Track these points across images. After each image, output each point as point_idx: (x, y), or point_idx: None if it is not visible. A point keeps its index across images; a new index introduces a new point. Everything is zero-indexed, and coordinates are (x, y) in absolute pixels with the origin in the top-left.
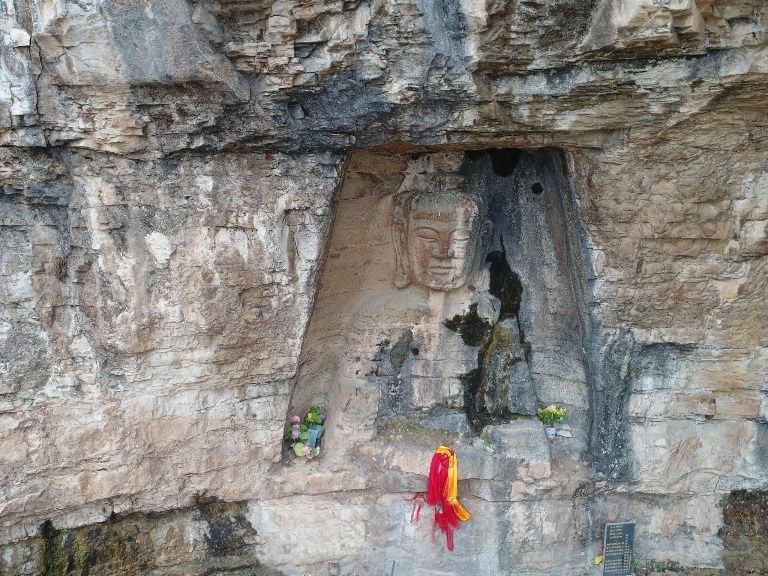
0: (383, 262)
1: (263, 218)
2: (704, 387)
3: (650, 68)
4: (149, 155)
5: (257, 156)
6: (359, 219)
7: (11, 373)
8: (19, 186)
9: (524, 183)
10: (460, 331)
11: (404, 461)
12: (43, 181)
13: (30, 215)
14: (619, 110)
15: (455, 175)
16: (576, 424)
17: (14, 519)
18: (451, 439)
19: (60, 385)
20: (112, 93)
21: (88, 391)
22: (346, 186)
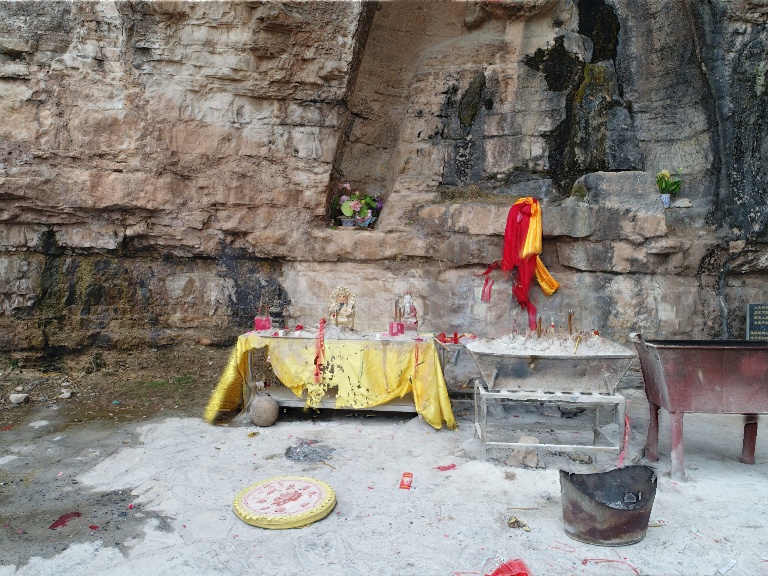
0: None
1: None
2: None
3: None
4: None
5: None
6: None
7: (30, 28)
8: None
9: None
10: (543, 70)
11: (474, 220)
12: None
13: None
14: None
15: None
16: (696, 195)
17: (12, 209)
18: None
19: (81, 54)
20: None
21: (111, 71)
22: None
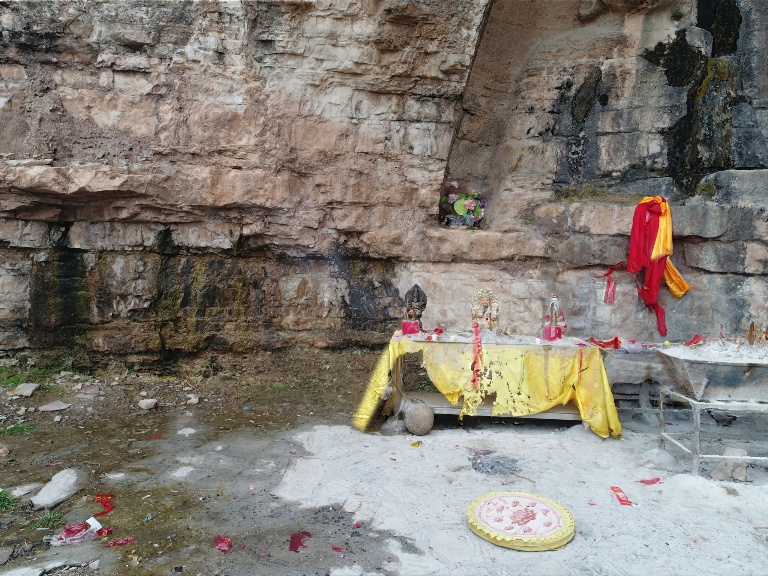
0: None
1: None
2: None
3: None
4: None
5: None
6: None
7: (152, 19)
8: None
9: None
10: (664, 65)
11: (595, 219)
12: None
13: None
14: None
15: None
16: None
17: (132, 207)
18: None
19: (202, 47)
20: None
21: (231, 64)
22: None
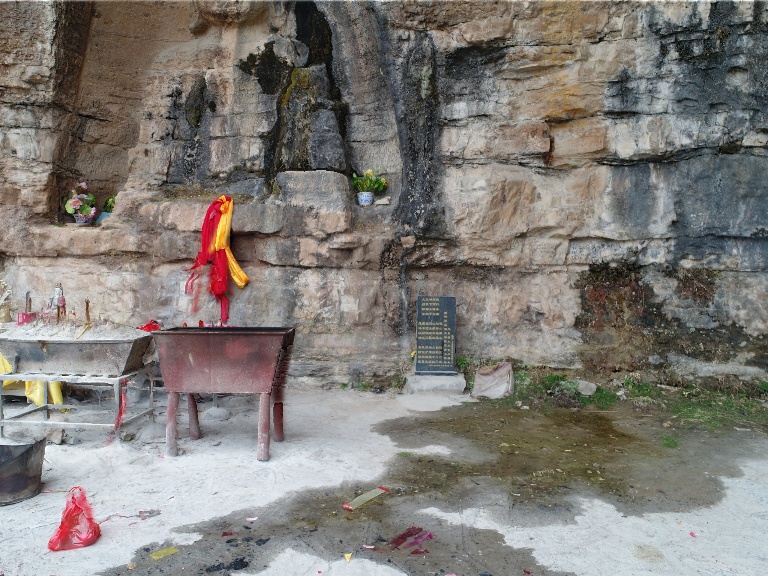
0: (180, 7)
1: None
2: (534, 116)
3: None
4: None
5: None
6: None
7: None
8: None
9: None
10: (256, 74)
11: (181, 217)
12: None
13: None
14: None
15: None
16: (398, 193)
17: None
18: (242, 200)
19: None
20: None
21: None
22: None
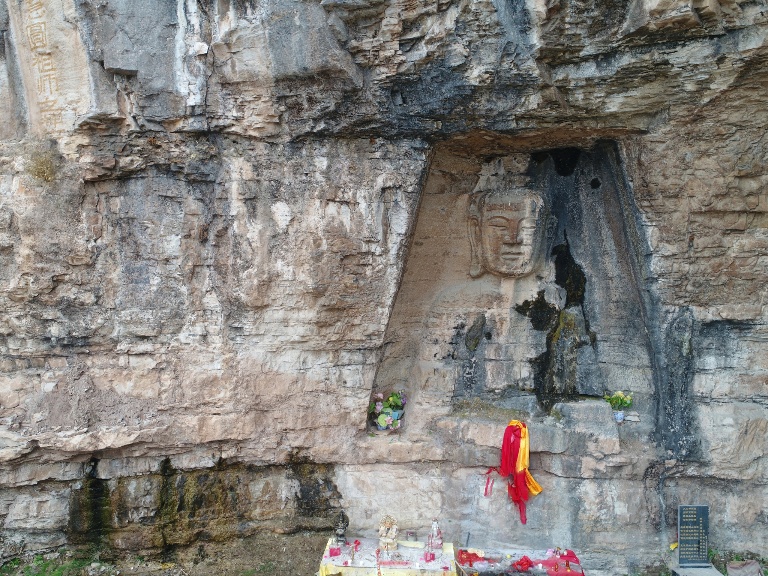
0: (460, 255)
1: (364, 194)
2: (767, 368)
3: (680, 48)
4: (281, 139)
5: (363, 141)
6: (440, 213)
7: (156, 319)
8: (182, 164)
9: (583, 180)
10: (529, 315)
11: (478, 434)
12: (200, 160)
13: (185, 190)
14: (659, 90)
15: (523, 176)
16: (643, 410)
17: (143, 450)
18: (522, 417)
19: (191, 333)
20: (261, 87)
21: (212, 342)
22: (430, 181)
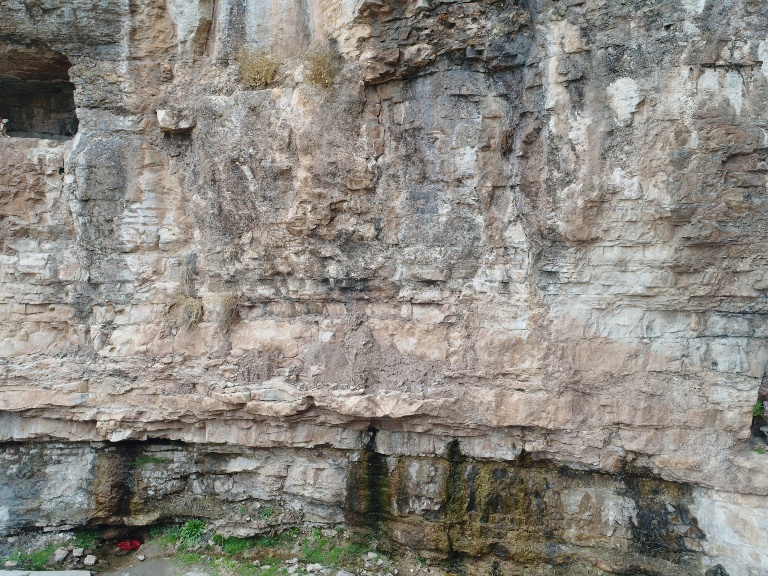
0: None
1: None
2: None
3: None
4: None
5: None
6: None
7: (445, 258)
8: (481, 46)
9: None
10: None
11: None
12: (505, 34)
13: (484, 85)
14: None
15: None
16: None
17: (426, 424)
18: None
19: (489, 279)
20: None
21: (515, 291)
22: None
